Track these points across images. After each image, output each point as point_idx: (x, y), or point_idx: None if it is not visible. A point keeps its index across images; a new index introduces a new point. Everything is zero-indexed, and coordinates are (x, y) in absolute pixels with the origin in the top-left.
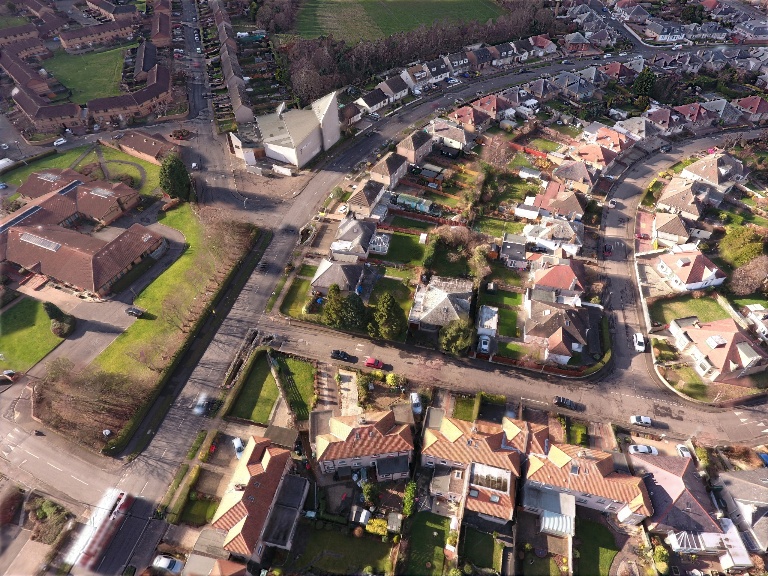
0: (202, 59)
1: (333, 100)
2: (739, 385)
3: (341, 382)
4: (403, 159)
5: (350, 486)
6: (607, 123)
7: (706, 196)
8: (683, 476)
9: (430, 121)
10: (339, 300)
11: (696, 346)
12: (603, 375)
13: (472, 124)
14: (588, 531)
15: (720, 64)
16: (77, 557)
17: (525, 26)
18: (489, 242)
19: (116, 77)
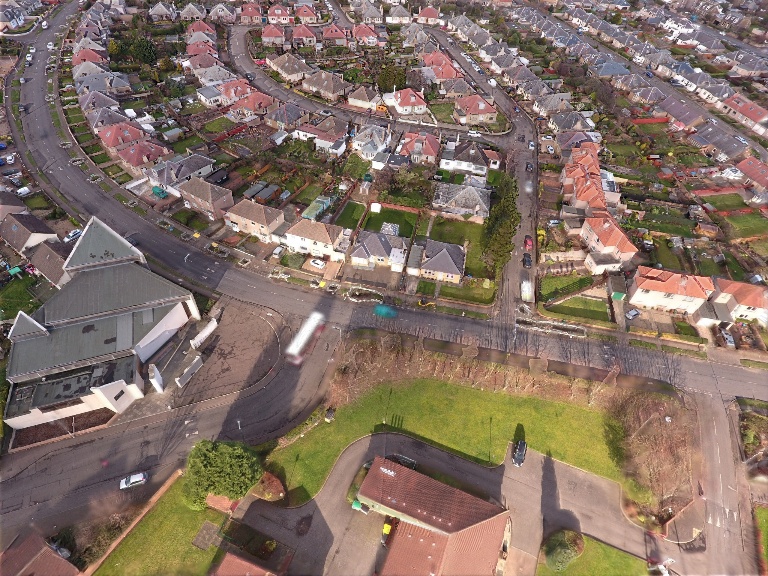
0: None
1: None
2: None
3: None
4: None
5: None
6: (189, 89)
7: None
8: None
9: (126, 187)
10: None
11: (481, 114)
12: None
13: (170, 152)
14: None
15: (110, 19)
16: (760, 400)
17: None
18: None
19: None
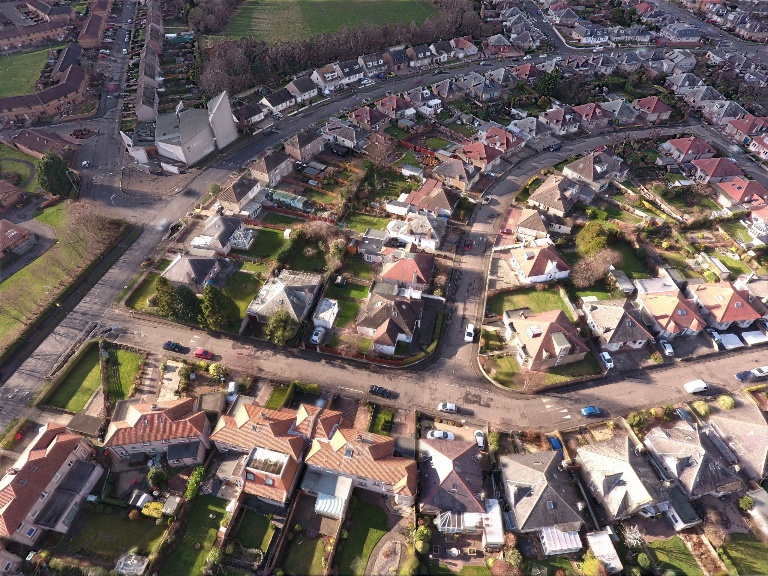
0: (126, 60)
1: (223, 99)
2: (554, 373)
3: (165, 372)
4: (285, 157)
5: (143, 471)
6: (506, 122)
7: (576, 193)
8: (455, 459)
9: None
10: (168, 292)
11: (517, 336)
12: (426, 364)
13: (368, 123)
14: (364, 513)
15: (634, 65)
16: None
17: (450, 28)
18: (354, 237)
19: (35, 77)
